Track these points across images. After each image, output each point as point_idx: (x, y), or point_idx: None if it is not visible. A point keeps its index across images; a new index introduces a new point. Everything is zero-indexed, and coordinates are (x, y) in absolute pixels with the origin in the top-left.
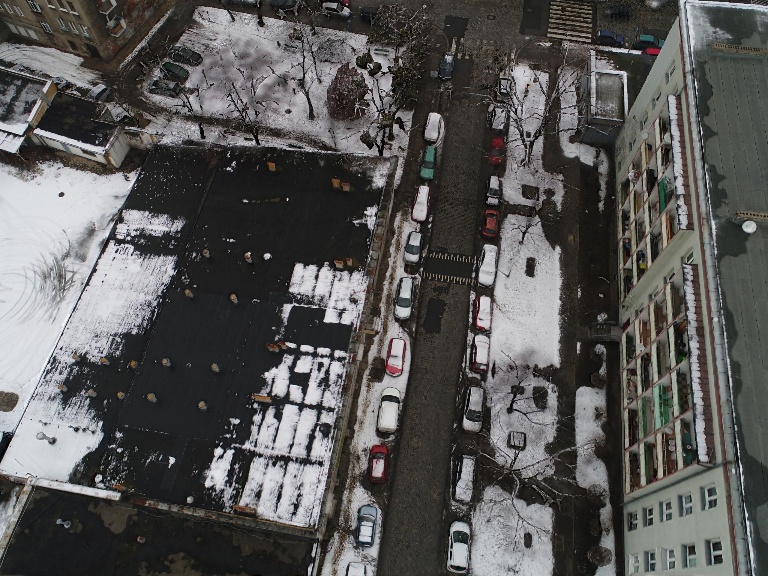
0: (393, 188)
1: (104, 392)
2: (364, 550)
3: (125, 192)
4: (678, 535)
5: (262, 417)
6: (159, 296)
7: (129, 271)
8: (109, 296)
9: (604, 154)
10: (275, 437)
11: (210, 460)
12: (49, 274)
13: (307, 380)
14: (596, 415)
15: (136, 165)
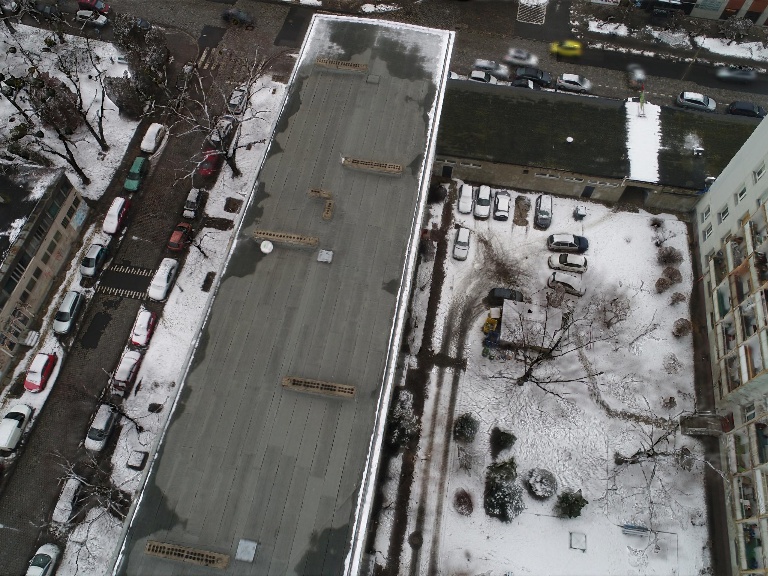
0: (81, 199)
1: None
2: None
3: None
4: None
5: None
6: None
7: None
8: None
9: None
10: None
11: None
12: None
13: None
14: None
15: None
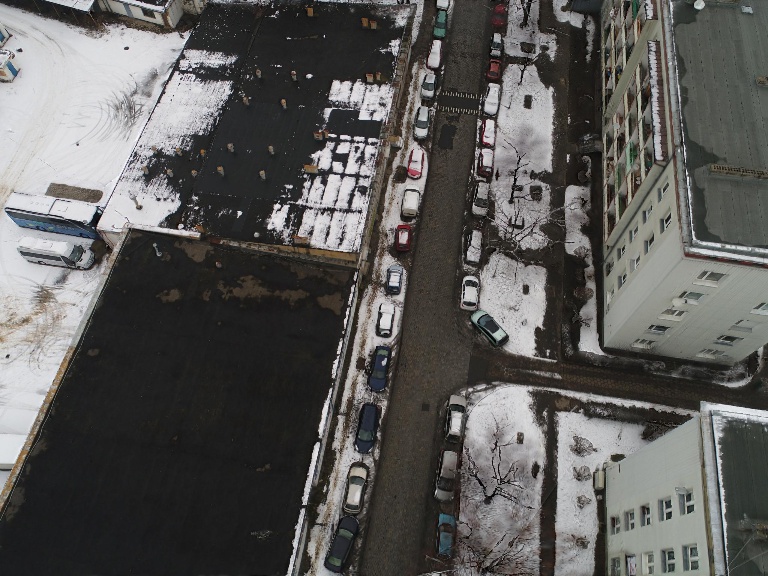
0: (411, 39)
1: (179, 174)
2: (393, 297)
3: (181, 46)
4: (642, 237)
5: (311, 183)
6: (219, 109)
7: (193, 92)
8: (177, 110)
9: (591, 19)
10: (322, 196)
11: (270, 212)
12: (121, 106)
13: (346, 158)
14: (582, 205)
15: (189, 26)
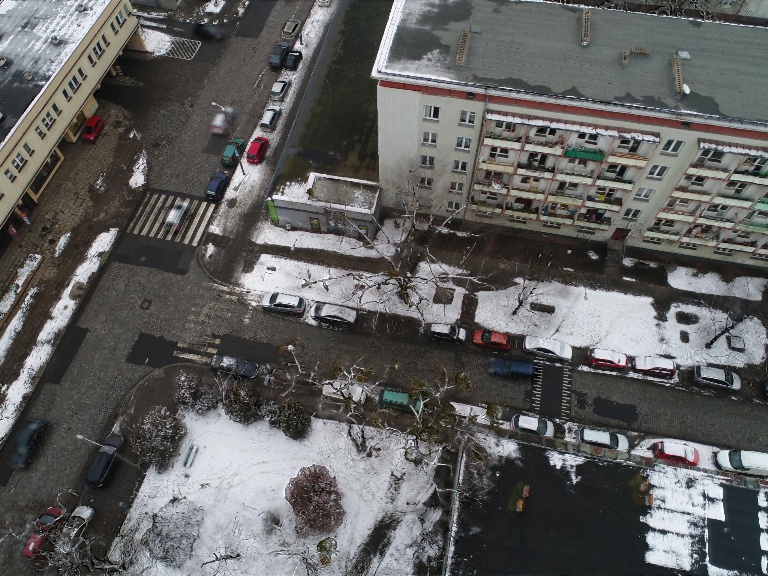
0: None
1: None
2: None
3: None
4: None
5: None
6: None
7: None
8: None
9: (392, 220)
10: None
11: None
12: None
13: None
14: (694, 276)
15: None
